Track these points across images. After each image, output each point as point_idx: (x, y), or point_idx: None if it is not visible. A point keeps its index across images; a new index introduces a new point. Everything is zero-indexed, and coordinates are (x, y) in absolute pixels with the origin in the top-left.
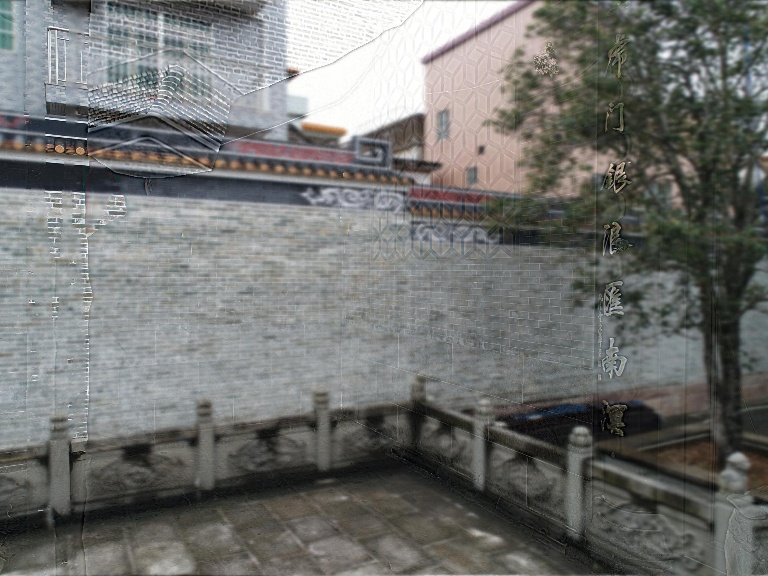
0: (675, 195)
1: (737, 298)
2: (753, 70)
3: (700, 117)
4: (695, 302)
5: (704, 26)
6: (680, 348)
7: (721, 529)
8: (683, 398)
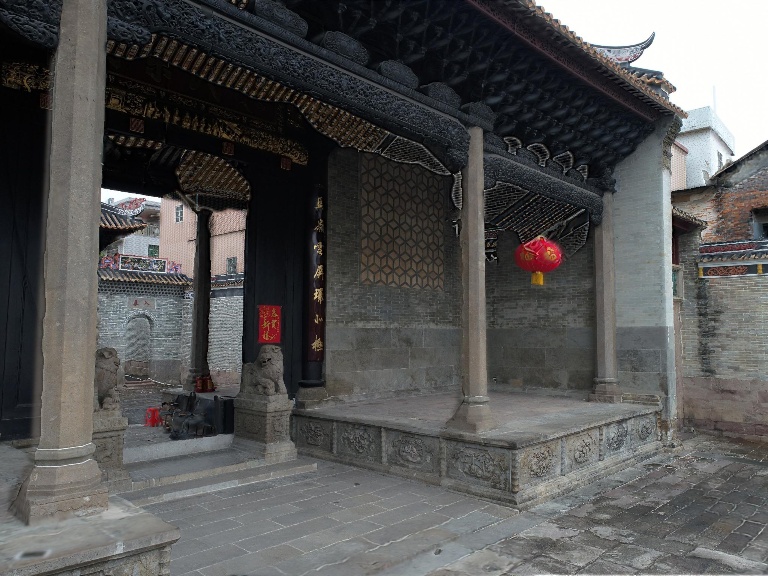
0: (5, 223)
1: (35, 280)
2: (48, 175)
3: (20, 186)
4: (13, 281)
5: (25, 142)
6: (5, 306)
7: (23, 397)
8: (5, 333)
